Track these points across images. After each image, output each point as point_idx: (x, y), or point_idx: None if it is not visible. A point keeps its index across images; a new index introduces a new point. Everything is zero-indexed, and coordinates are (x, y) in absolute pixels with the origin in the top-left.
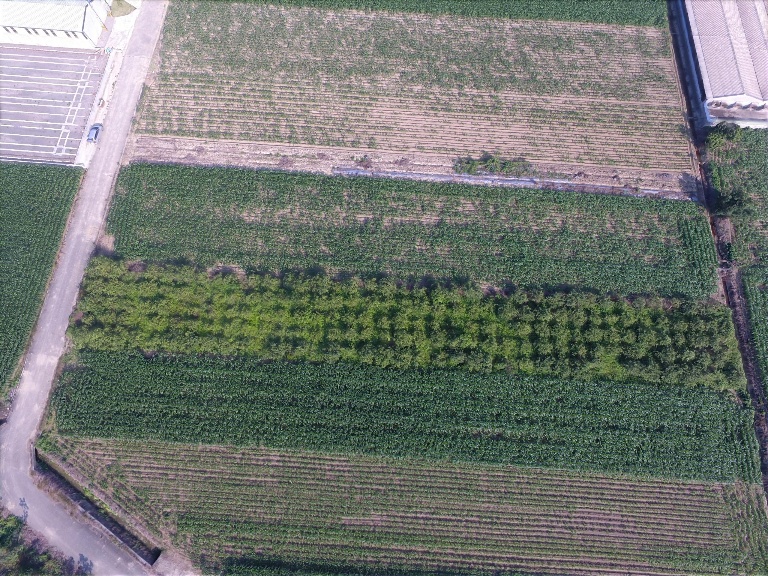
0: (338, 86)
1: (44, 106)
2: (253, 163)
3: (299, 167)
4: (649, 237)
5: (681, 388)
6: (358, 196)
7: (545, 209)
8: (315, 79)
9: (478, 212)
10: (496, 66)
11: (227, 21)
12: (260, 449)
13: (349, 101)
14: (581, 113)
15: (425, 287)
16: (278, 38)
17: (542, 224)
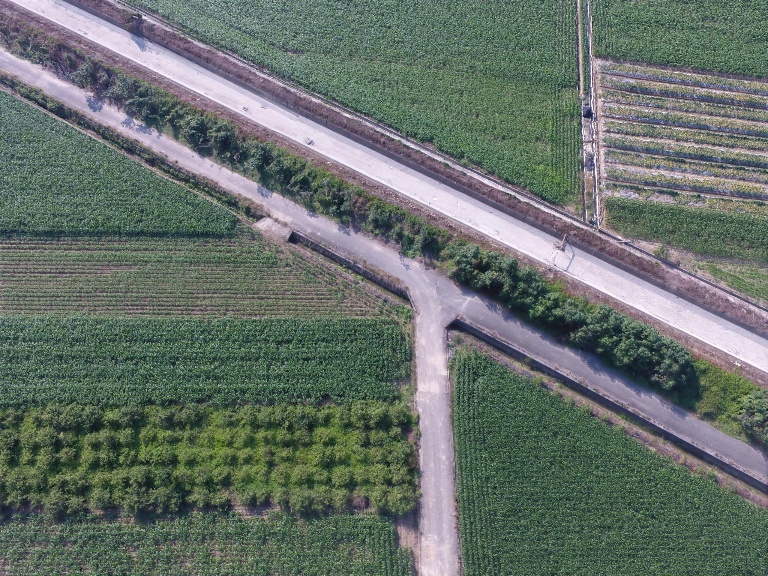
0: None
1: None
2: None
3: None
4: None
5: None
6: None
7: None
8: None
9: None
10: None
11: None
12: None
13: None
14: None
15: None
16: None
17: None
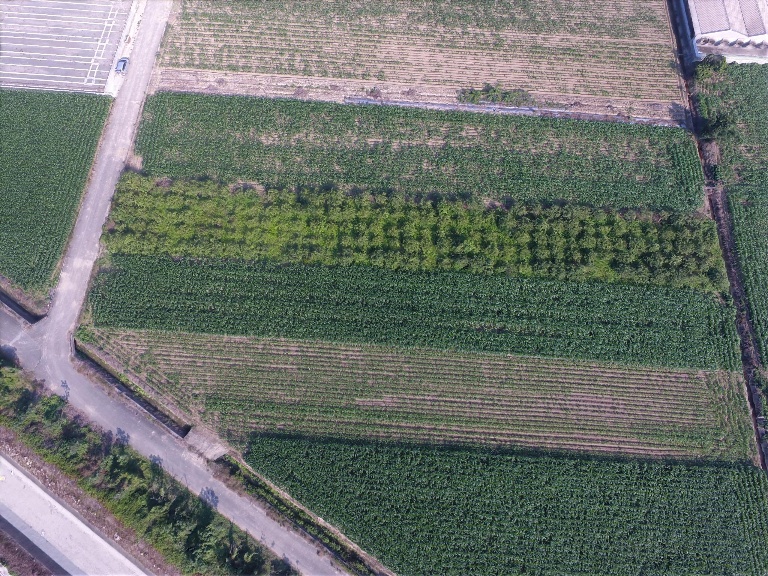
0: (349, 25)
1: (74, 42)
2: (270, 93)
3: (313, 97)
4: (640, 159)
5: (668, 289)
6: (369, 122)
7: (543, 134)
8: (327, 19)
9: (480, 137)
10: (497, 8)
11: None
12: (280, 341)
13: (359, 39)
14: (577, 50)
15: (431, 200)
16: None
17: (540, 147)
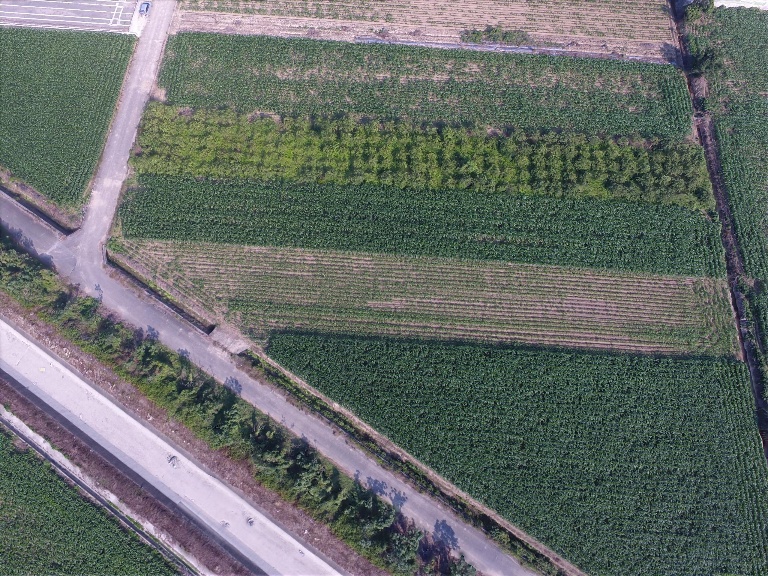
0: None
1: None
2: (284, 34)
3: (325, 37)
4: (633, 92)
5: (658, 205)
6: (377, 58)
7: (542, 70)
8: None
9: (483, 72)
10: None
11: None
12: (297, 251)
13: None
14: None
15: (437, 127)
16: None
17: (539, 82)
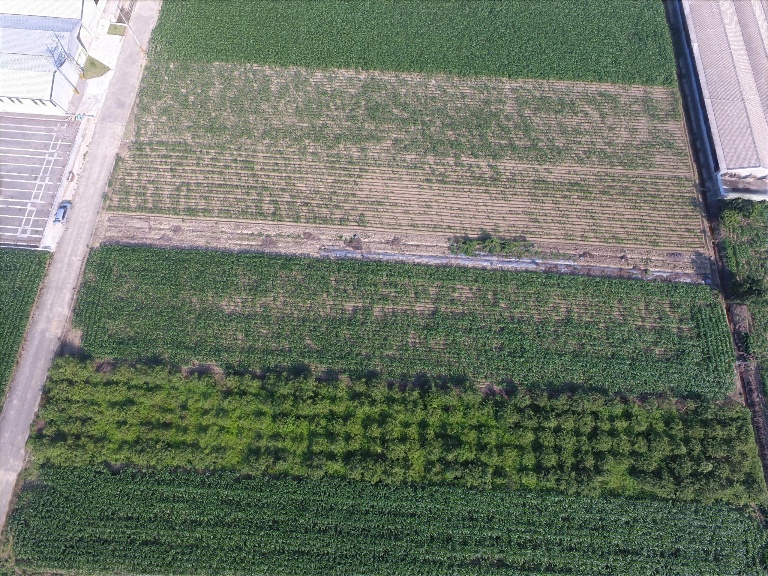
0: (326, 155)
1: (9, 181)
2: (234, 244)
3: (283, 248)
4: (660, 326)
5: (698, 505)
6: (346, 282)
7: (548, 295)
8: (301, 148)
9: (476, 299)
10: (495, 132)
11: (207, 83)
12: None
13: (337, 172)
14: (586, 184)
15: (419, 389)
16: (262, 102)
17: (545, 313)
